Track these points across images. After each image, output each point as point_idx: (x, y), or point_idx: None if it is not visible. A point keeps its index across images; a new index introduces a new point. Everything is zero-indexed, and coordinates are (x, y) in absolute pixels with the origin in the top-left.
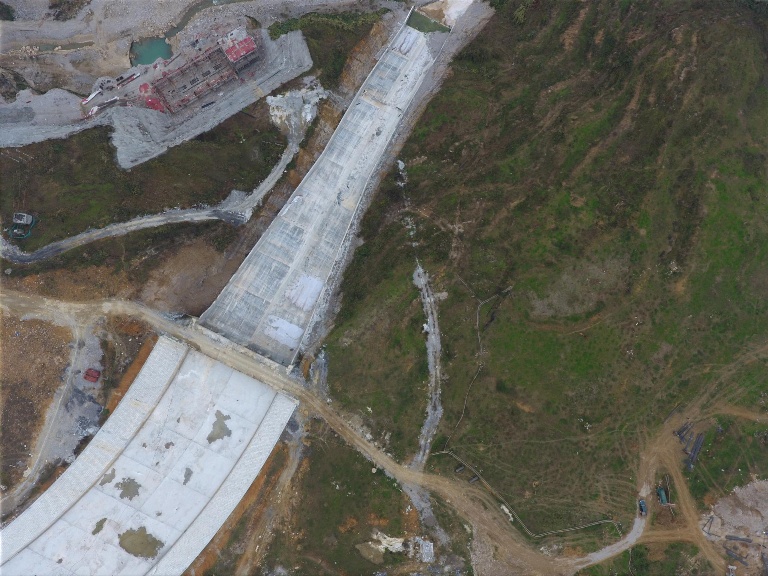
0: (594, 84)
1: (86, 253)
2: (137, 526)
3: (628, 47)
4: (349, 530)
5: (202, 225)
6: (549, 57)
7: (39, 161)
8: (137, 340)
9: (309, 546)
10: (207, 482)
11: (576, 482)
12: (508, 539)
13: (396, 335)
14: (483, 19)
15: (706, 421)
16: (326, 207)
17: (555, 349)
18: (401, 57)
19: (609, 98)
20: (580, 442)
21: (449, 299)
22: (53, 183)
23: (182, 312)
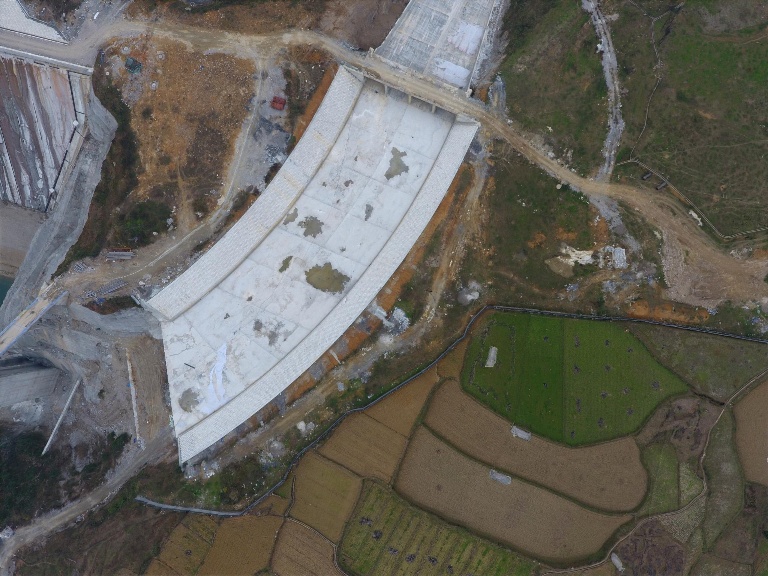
0: None
1: None
2: (322, 262)
3: None
4: (538, 245)
5: None
6: None
7: None
8: (320, 67)
9: (500, 262)
10: (388, 217)
11: (763, 184)
12: (698, 243)
13: (569, 59)
14: None
15: None
16: None
17: (732, 59)
18: None
19: None
20: (765, 145)
21: (621, 19)
22: None
23: (356, 47)
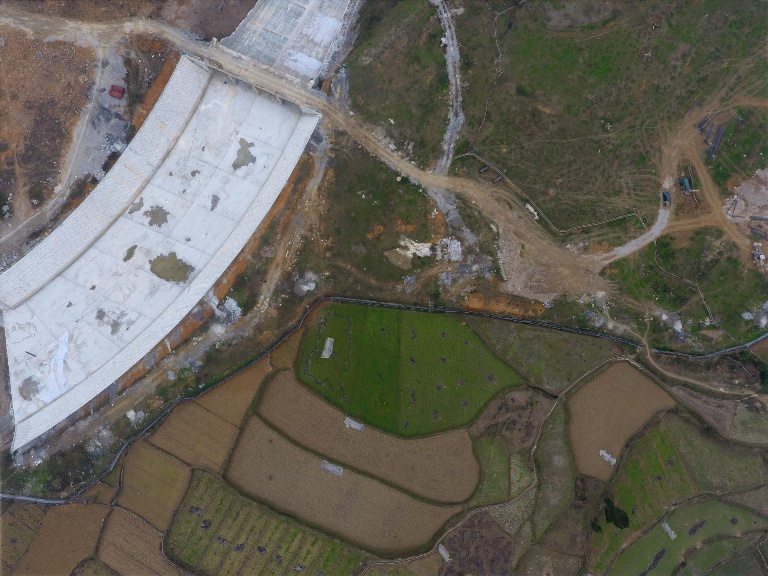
0: None
1: None
2: (167, 252)
3: None
4: (377, 237)
5: None
6: None
7: None
8: (160, 56)
9: (338, 254)
10: (234, 207)
11: (599, 179)
12: (534, 237)
13: (415, 52)
14: None
15: (726, 113)
16: None
17: (573, 54)
18: None
19: None
20: (602, 140)
21: (466, 13)
22: None
23: (202, 37)
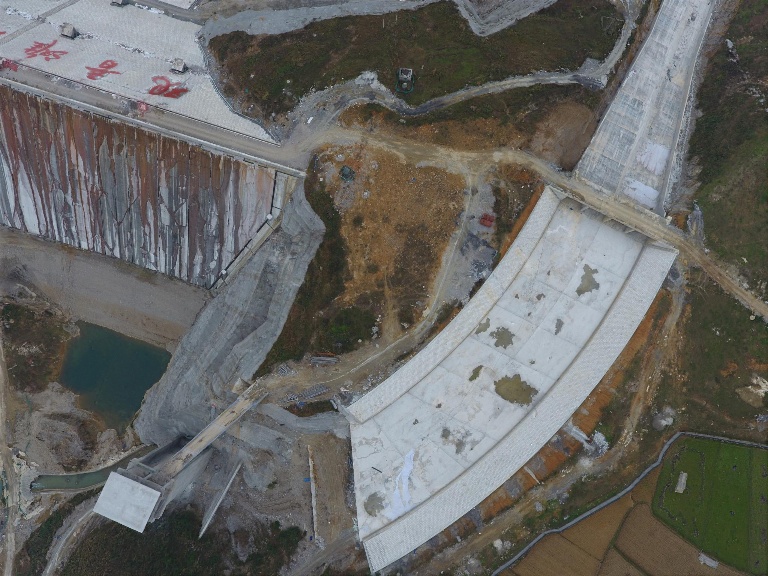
0: None
1: (474, 106)
2: (512, 374)
3: None
4: (730, 374)
5: (572, 86)
6: None
7: (402, 27)
8: (529, 187)
9: (693, 389)
10: (578, 333)
11: None
12: None
13: (763, 192)
14: None
15: None
16: (659, 82)
17: None
18: None
19: None
20: None
21: None
22: (418, 47)
23: (558, 166)
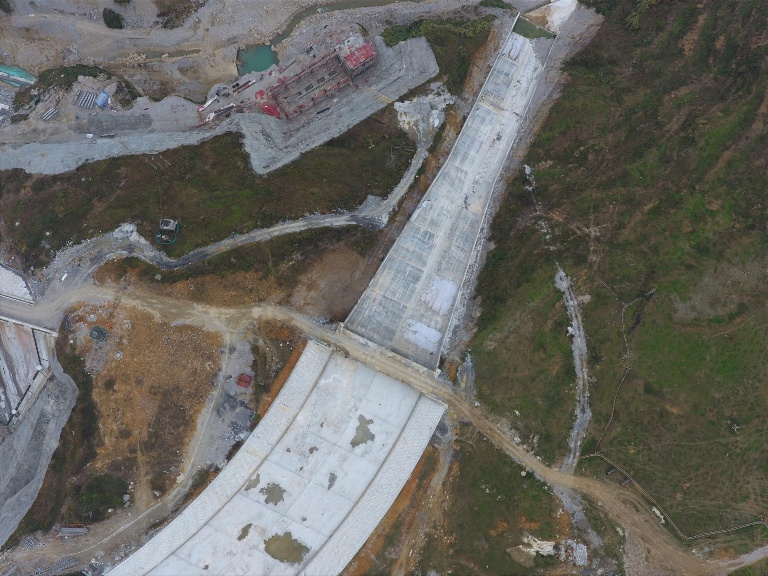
0: (720, 89)
1: (234, 258)
2: (282, 531)
3: (754, 52)
4: (500, 534)
5: (344, 230)
6: (668, 62)
7: (176, 167)
8: (288, 345)
9: (461, 550)
10: (351, 487)
11: (727, 484)
12: (660, 541)
13: (540, 338)
14: (591, 25)
15: None
16: (454, 211)
17: (701, 351)
18: (511, 63)
19: (738, 102)
20: (730, 444)
21: (593, 302)
22: (191, 189)
23: (327, 317)
